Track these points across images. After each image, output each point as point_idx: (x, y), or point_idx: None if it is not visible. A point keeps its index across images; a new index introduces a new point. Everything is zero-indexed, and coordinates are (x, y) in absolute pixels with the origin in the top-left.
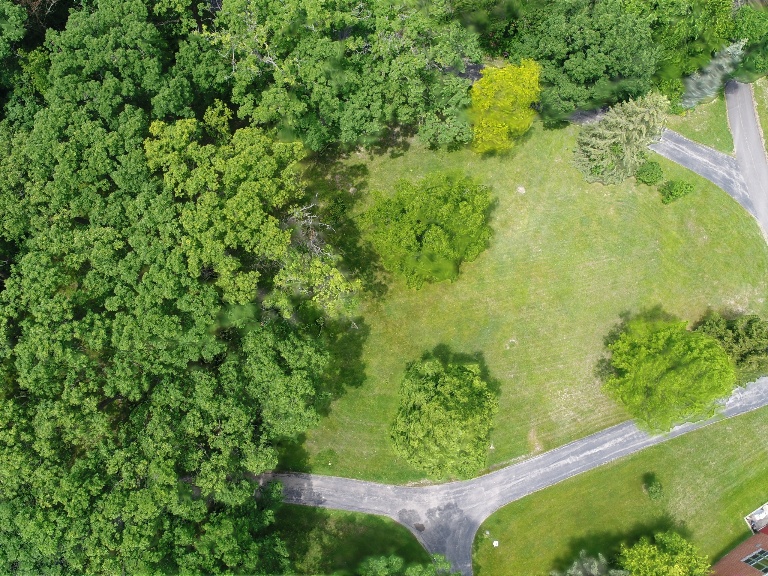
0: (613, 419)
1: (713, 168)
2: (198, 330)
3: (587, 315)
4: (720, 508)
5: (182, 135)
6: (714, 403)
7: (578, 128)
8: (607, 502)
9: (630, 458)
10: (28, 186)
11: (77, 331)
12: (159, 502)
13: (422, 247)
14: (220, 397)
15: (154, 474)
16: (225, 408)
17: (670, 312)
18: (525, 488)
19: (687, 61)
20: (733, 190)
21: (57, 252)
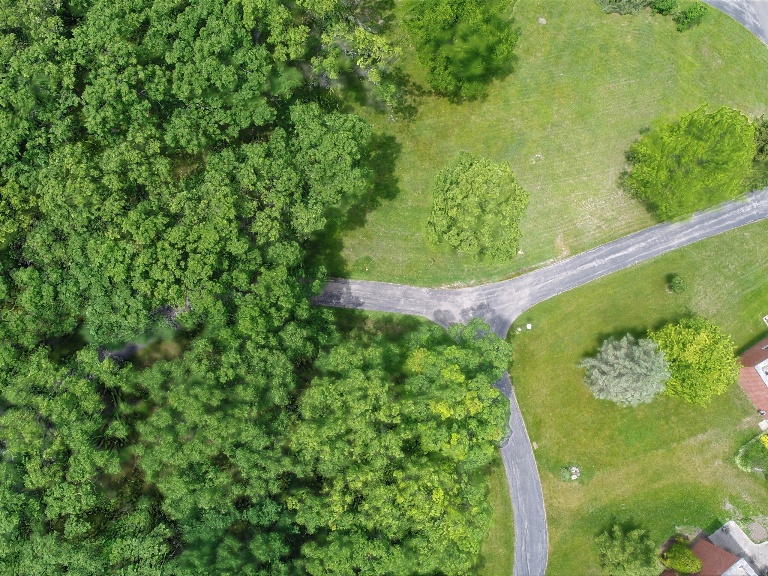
0: (636, 226)
1: (725, 1)
2: (252, 85)
3: (608, 132)
4: (740, 309)
5: None
6: (736, 164)
7: None
8: (632, 300)
9: (653, 261)
10: None
11: (142, 73)
12: (221, 233)
13: (458, 19)
14: (271, 159)
15: (215, 207)
16: (276, 167)
17: None
18: (554, 289)
19: None
20: (744, 20)
21: (119, 11)
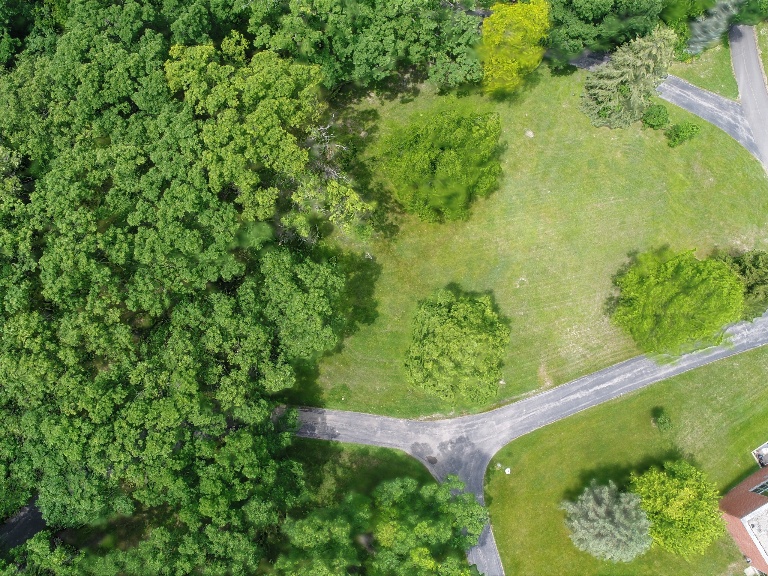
0: (622, 355)
1: (718, 113)
2: (218, 246)
3: (595, 254)
4: (728, 442)
5: (202, 55)
6: (723, 323)
7: (585, 72)
8: (616, 435)
9: (639, 393)
10: (51, 106)
11: (101, 242)
12: (181, 410)
13: (436, 170)
14: (239, 316)
15: (176, 383)
16: (244, 326)
17: (677, 251)
18: (536, 422)
19: (693, 3)
20: (738, 134)
21: (80, 169)
